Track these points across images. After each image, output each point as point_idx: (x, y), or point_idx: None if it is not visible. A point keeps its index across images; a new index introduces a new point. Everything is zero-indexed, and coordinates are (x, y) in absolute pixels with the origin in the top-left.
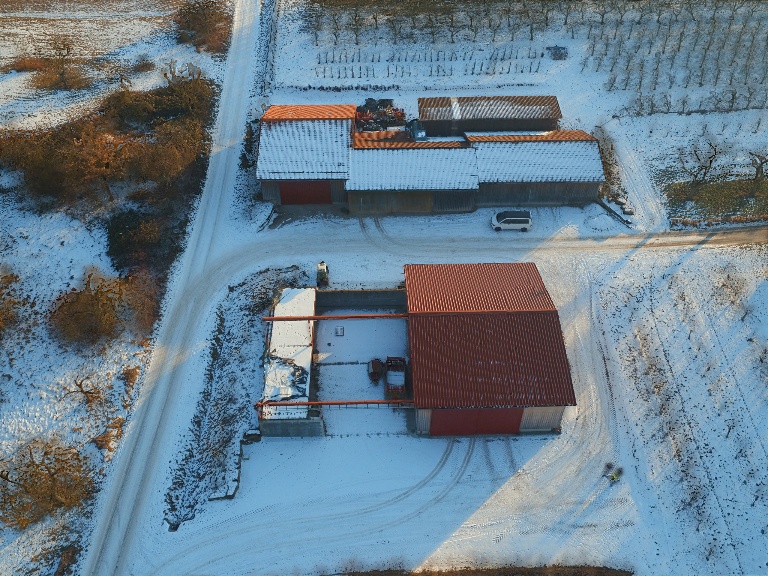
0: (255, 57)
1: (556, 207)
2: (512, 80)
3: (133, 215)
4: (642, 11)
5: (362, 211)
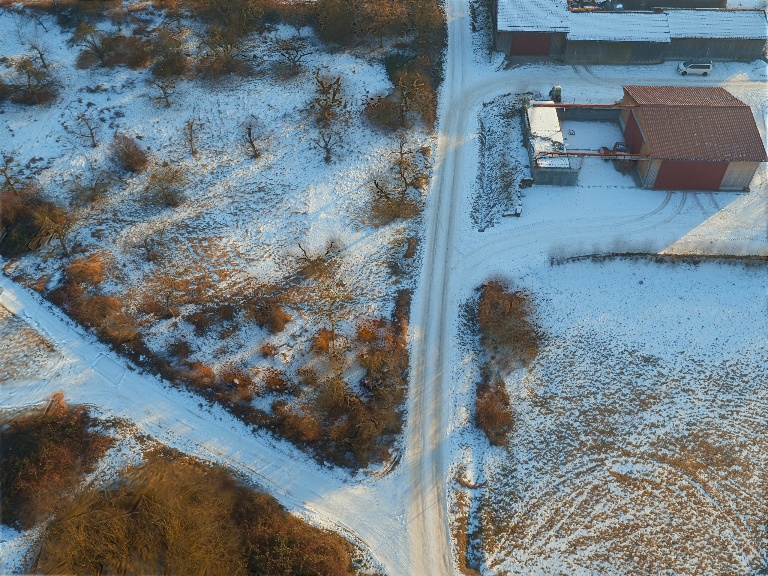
0: None
1: (727, 62)
2: None
3: (400, 57)
4: None
5: (574, 60)
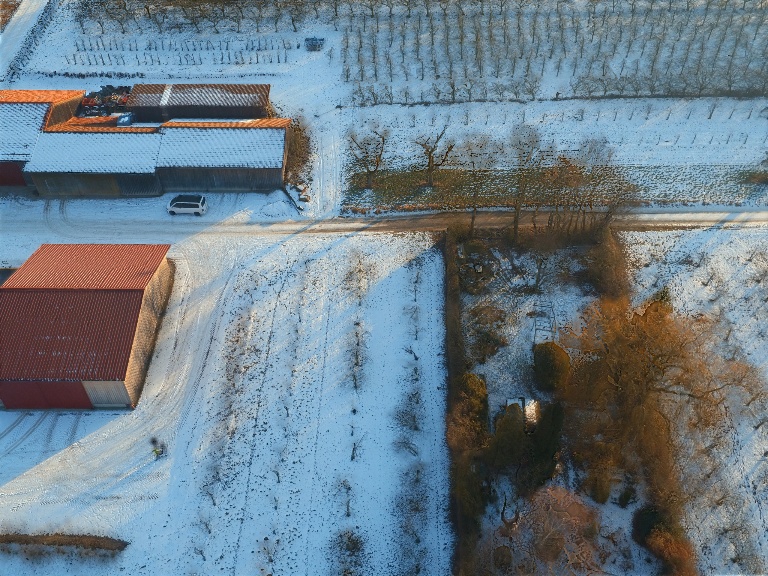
0: (21, 44)
1: (243, 193)
2: (256, 70)
3: None
4: (407, 5)
5: (51, 193)
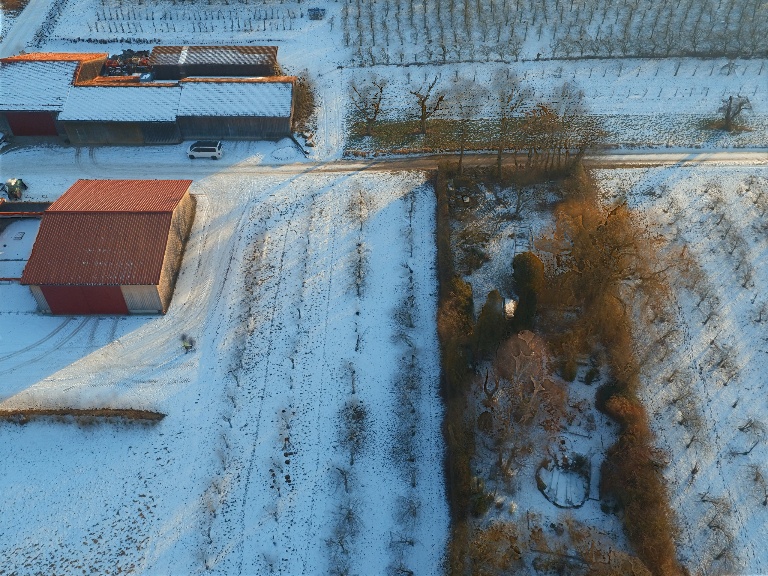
0: (45, 15)
1: (254, 141)
2: (264, 36)
3: None
4: None
5: (81, 141)
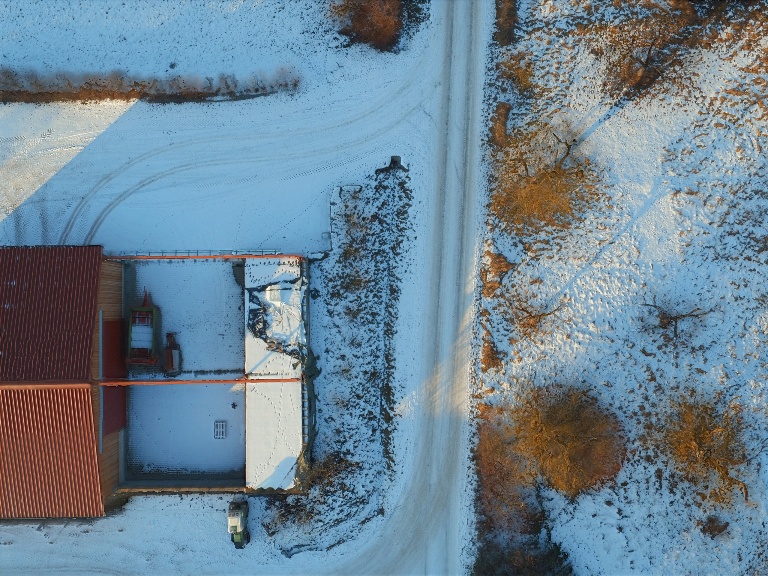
0: None
1: None
2: None
3: None
4: None
5: None
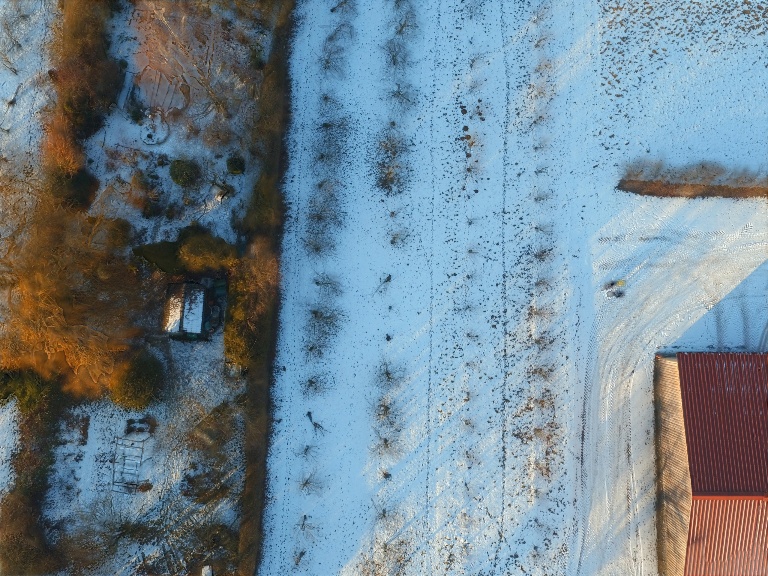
0: None
1: None
2: None
3: None
4: None
5: None
